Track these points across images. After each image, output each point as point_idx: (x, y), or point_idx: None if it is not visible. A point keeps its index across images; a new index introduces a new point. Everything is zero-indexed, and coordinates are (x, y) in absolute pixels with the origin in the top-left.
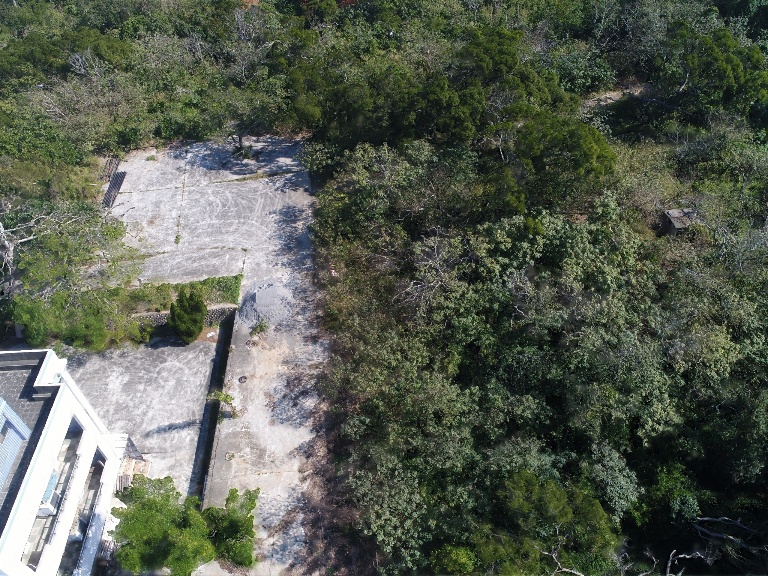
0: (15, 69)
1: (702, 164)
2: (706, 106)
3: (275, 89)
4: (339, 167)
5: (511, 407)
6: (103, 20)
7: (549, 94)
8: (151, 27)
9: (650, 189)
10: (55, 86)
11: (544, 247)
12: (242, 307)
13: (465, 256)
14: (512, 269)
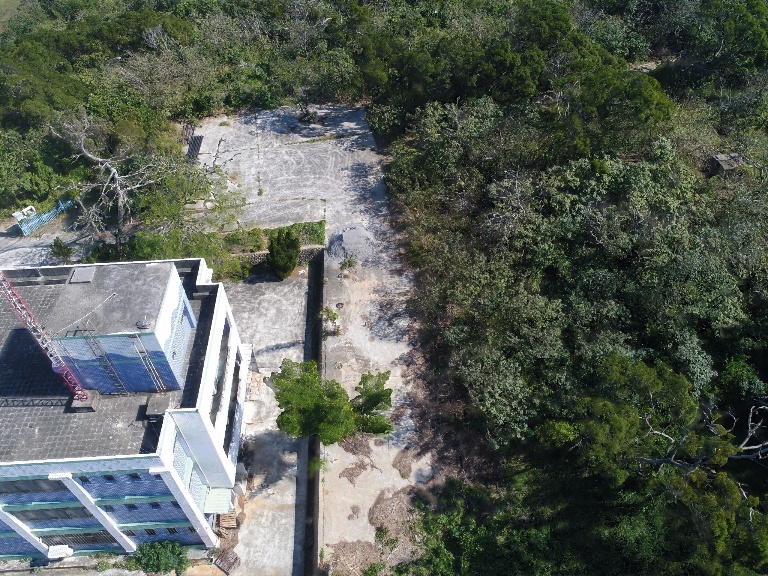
0: (85, 46)
1: (740, 120)
2: (742, 68)
3: (336, 60)
4: (410, 124)
5: (596, 310)
6: (155, 4)
7: (600, 57)
8: (202, 10)
9: (699, 136)
10: (129, 59)
11: (609, 184)
12: (330, 247)
13: (536, 195)
14: (580, 205)
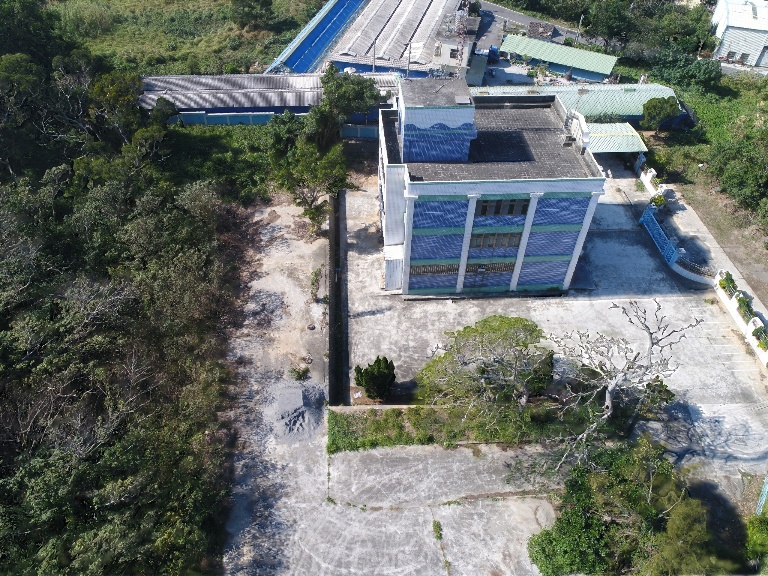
0: None
1: None
2: None
3: None
4: None
5: None
6: None
7: None
8: None
9: None
10: None
11: None
12: (321, 399)
13: None
14: None
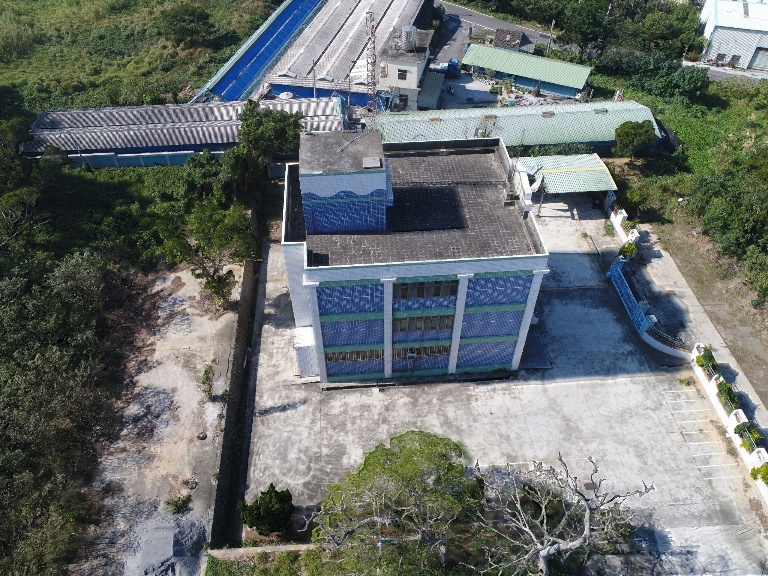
0: None
1: None
2: None
3: None
4: None
5: None
6: None
7: None
8: None
9: None
10: None
11: None
12: (199, 541)
13: None
14: None
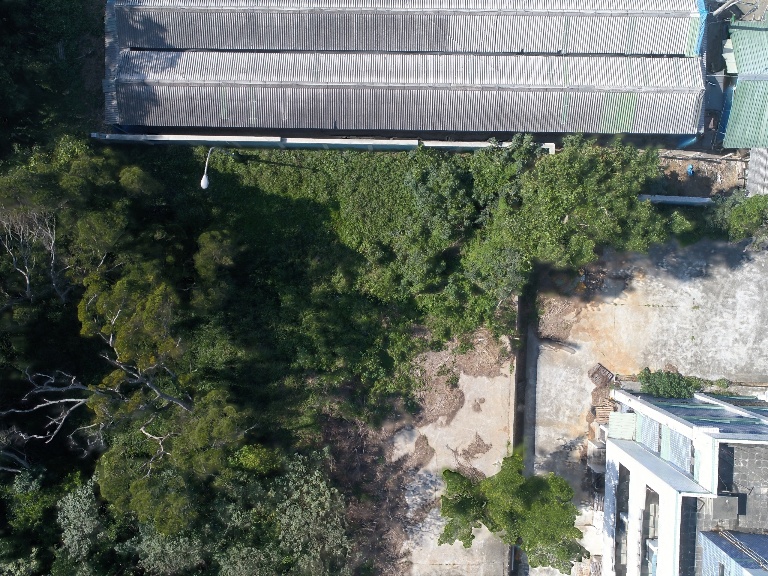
0: None
1: None
2: None
3: None
4: None
5: None
6: None
7: None
8: None
9: None
10: None
11: None
12: None
13: None
14: None
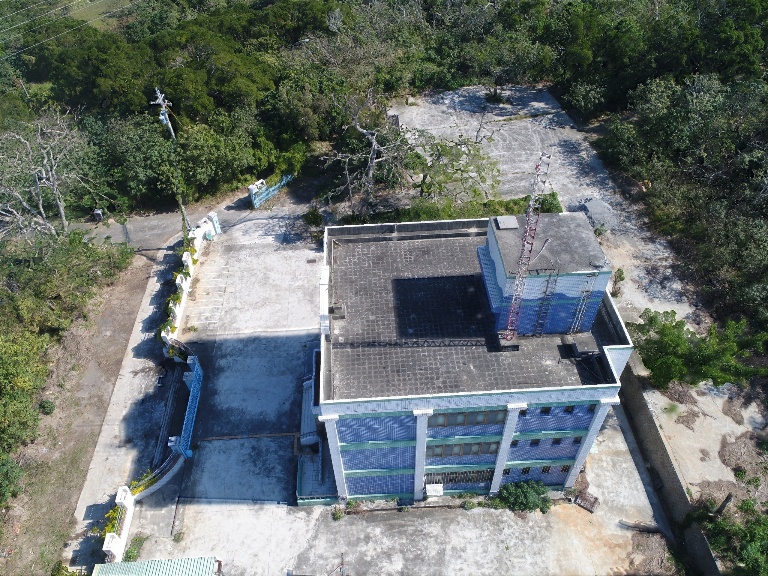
0: (253, 31)
1: None
2: None
3: None
4: (631, 100)
5: None
6: None
7: None
8: None
9: None
10: (309, 42)
11: None
12: None
13: None
14: None
